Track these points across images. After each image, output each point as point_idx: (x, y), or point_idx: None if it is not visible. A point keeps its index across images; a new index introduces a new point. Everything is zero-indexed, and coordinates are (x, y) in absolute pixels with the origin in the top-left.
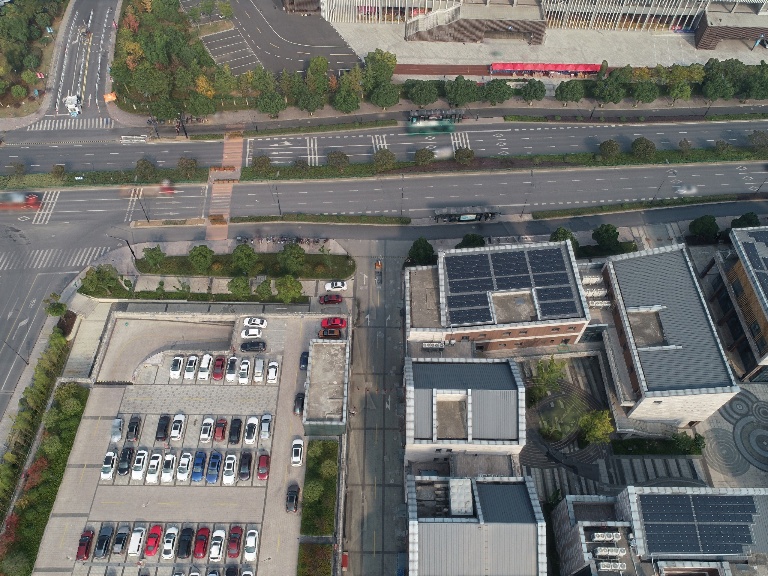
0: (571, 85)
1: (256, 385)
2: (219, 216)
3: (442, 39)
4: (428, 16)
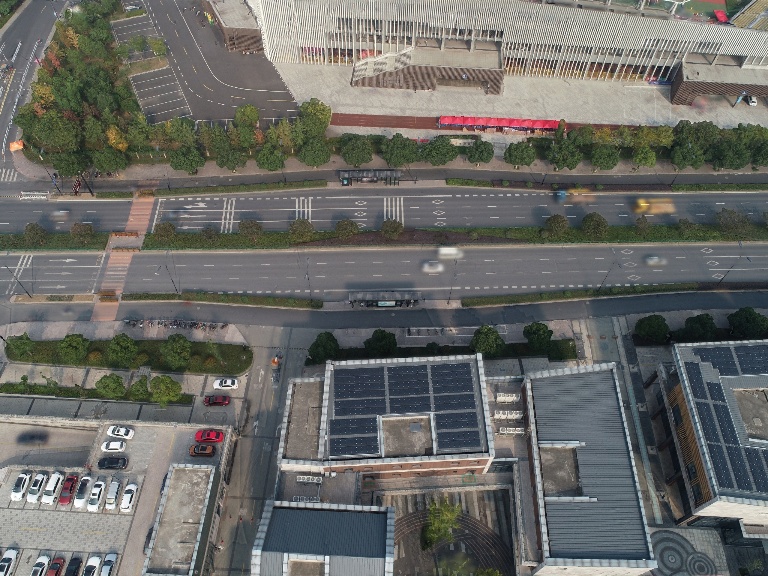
0: (520, 148)
1: (107, 513)
2: (110, 292)
3: (391, 85)
4: (378, 59)
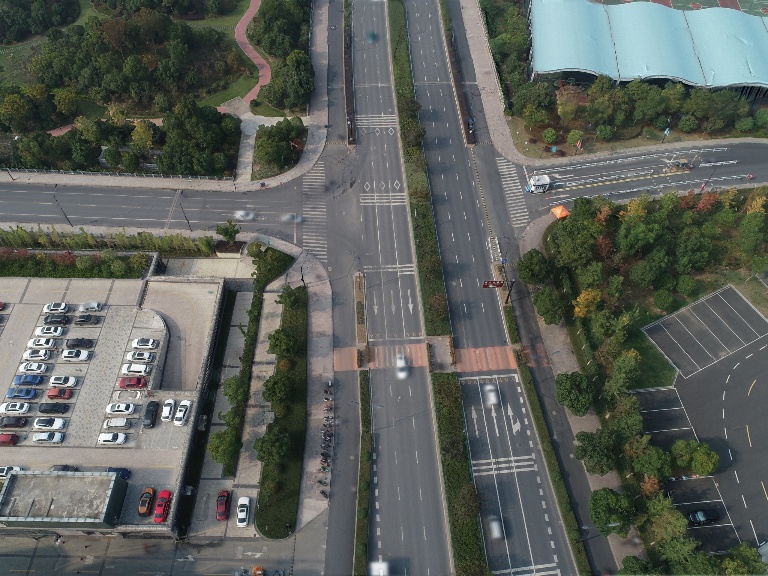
0: None
1: None
2: (367, 357)
3: None
4: None
